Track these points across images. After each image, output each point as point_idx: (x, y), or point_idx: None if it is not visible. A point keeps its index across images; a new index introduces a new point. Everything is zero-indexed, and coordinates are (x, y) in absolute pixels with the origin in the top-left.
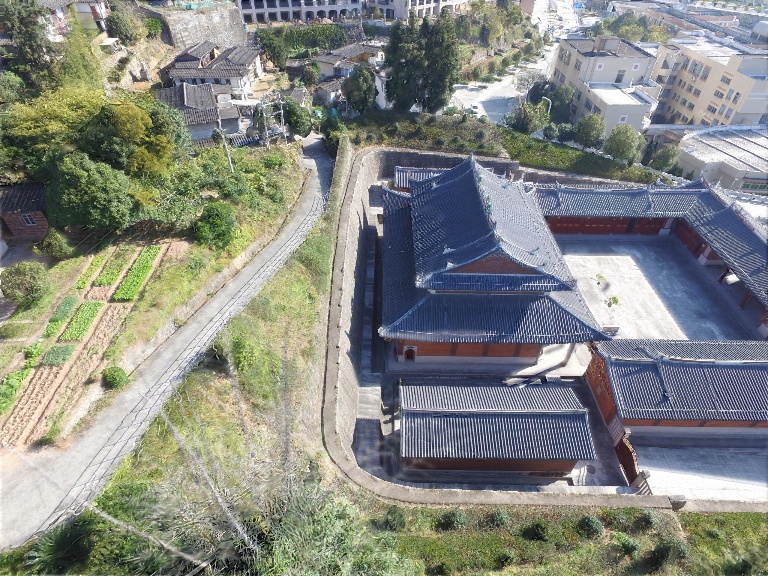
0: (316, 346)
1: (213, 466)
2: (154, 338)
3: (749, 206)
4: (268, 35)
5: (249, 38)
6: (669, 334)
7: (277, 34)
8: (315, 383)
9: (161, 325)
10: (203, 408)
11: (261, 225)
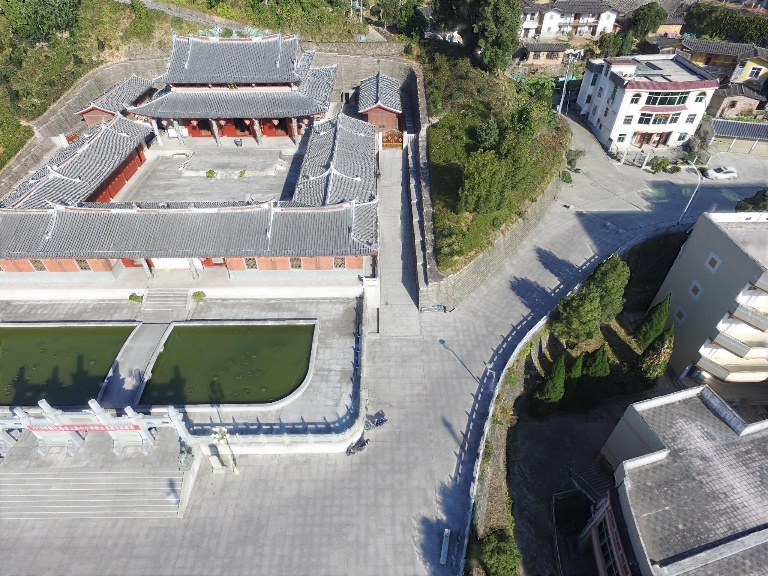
0: (169, 48)
1: (97, 15)
2: (158, 3)
3: (453, 417)
4: (698, 12)
5: (679, 10)
6: (167, 197)
7: (707, 13)
8: (152, 52)
9: (162, 2)
10: (121, 13)
11: (249, 20)
